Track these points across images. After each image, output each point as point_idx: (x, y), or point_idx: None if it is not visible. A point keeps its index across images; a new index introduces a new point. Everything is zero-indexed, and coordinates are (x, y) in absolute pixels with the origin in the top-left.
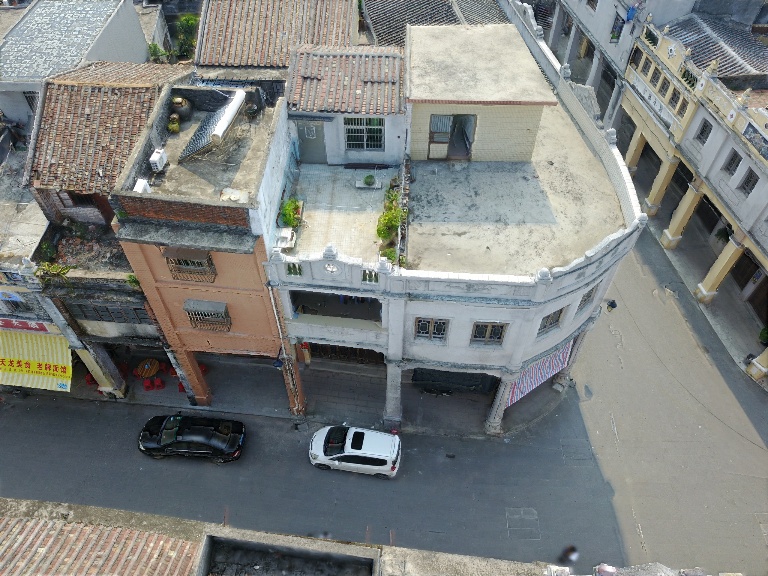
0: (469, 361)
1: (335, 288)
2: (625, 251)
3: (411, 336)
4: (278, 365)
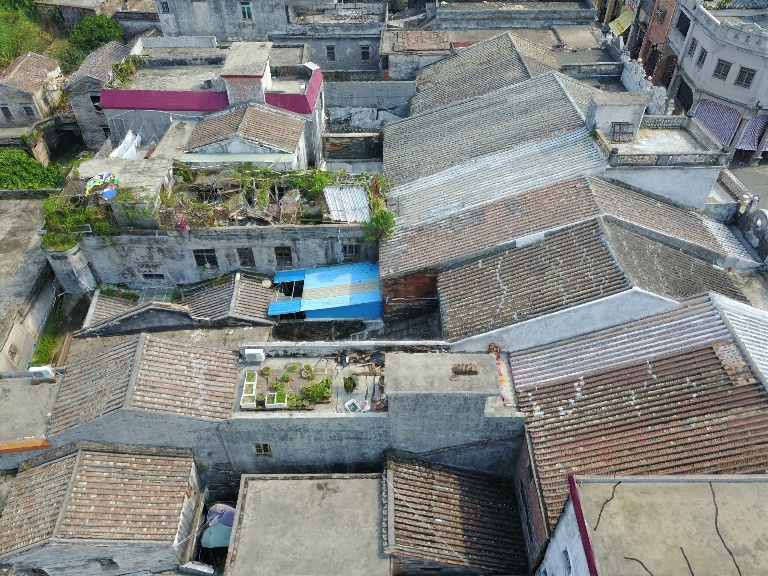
0: (691, 76)
1: (686, 9)
2: (767, 53)
3: (688, 50)
4: (655, 46)
